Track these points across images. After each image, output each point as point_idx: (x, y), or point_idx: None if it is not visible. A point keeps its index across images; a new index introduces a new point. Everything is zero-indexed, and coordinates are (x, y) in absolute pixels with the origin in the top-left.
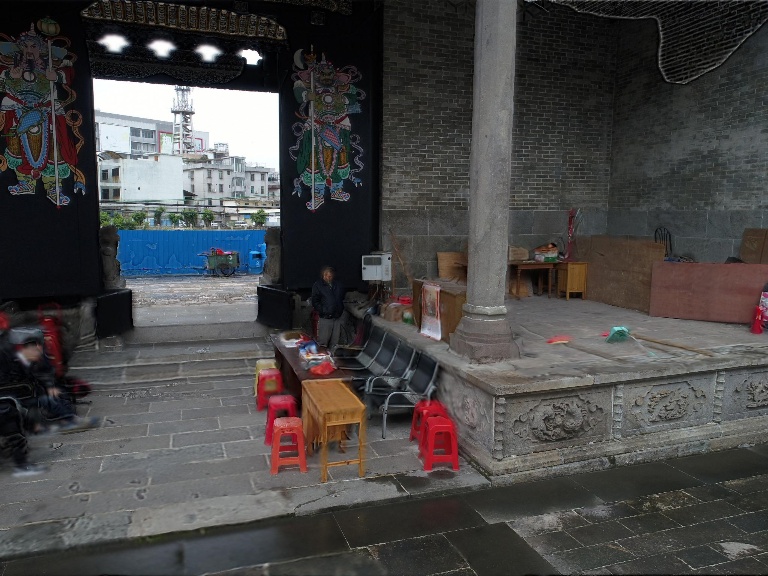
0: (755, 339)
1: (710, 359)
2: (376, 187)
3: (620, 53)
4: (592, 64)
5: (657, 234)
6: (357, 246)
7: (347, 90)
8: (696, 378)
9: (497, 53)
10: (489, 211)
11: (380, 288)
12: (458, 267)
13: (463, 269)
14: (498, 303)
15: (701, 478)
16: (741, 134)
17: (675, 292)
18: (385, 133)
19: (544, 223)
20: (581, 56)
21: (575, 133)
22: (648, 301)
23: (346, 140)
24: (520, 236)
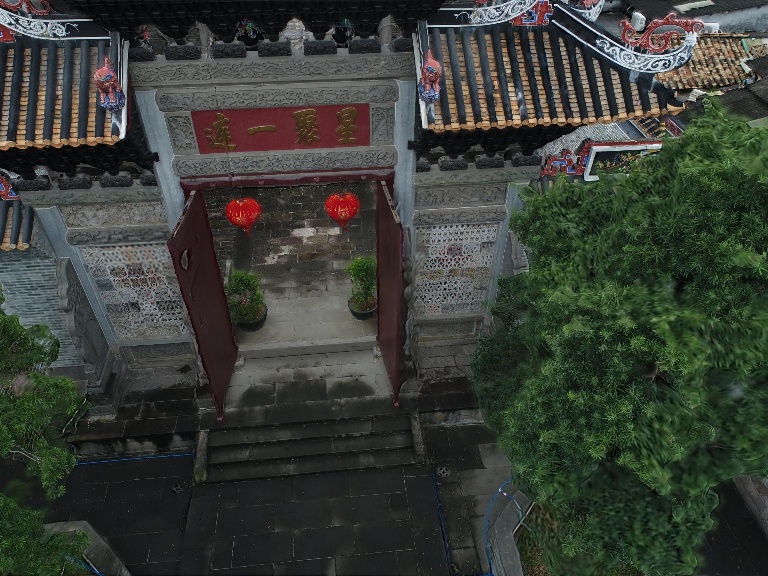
0: None
1: None
2: None
3: None
4: None
5: None
6: None
7: None
8: None
9: (383, 30)
10: None
11: None
12: None
13: None
14: None
15: (429, 159)
16: None
17: None
18: None
19: None
20: None
21: None
22: None
23: None
24: None
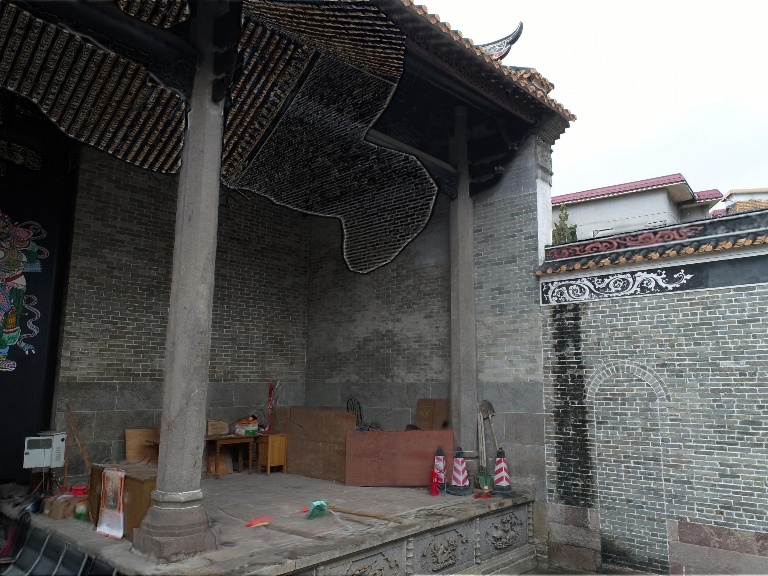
0: (433, 501)
1: (399, 526)
2: (52, 355)
3: (312, 242)
4: (288, 249)
5: (348, 404)
6: (19, 426)
7: (25, 246)
8: (389, 547)
9: (198, 229)
10: (185, 385)
11: (46, 477)
12: (149, 445)
13: (155, 448)
14: (193, 487)
15: None
16: (409, 318)
17: (366, 460)
18: (69, 296)
19: (244, 395)
20: (278, 241)
21: (274, 308)
22: (343, 471)
23: (18, 301)
24: (219, 409)
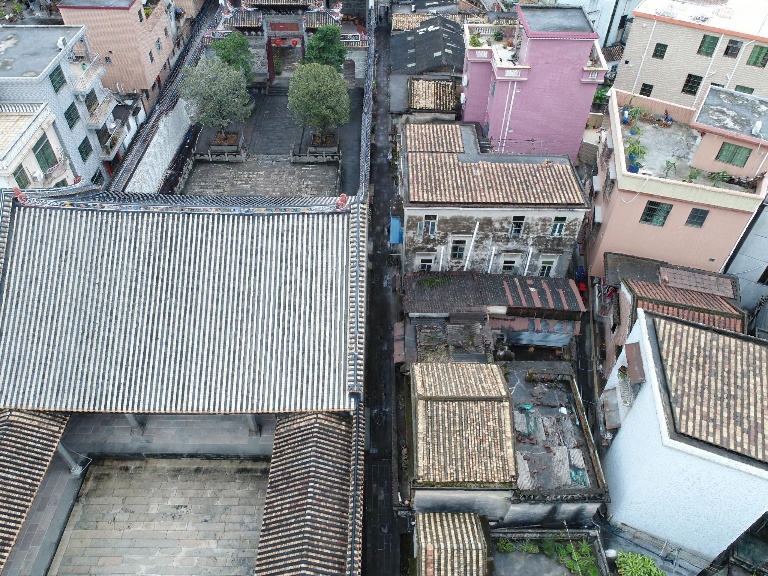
0: None
1: None
2: (328, 5)
3: None
4: None
5: None
6: None
7: None
8: None
9: None
10: None
11: None
12: None
13: None
14: None
15: None
16: None
17: None
18: None
19: (357, 10)
20: None
21: None
22: None
23: None
24: None
